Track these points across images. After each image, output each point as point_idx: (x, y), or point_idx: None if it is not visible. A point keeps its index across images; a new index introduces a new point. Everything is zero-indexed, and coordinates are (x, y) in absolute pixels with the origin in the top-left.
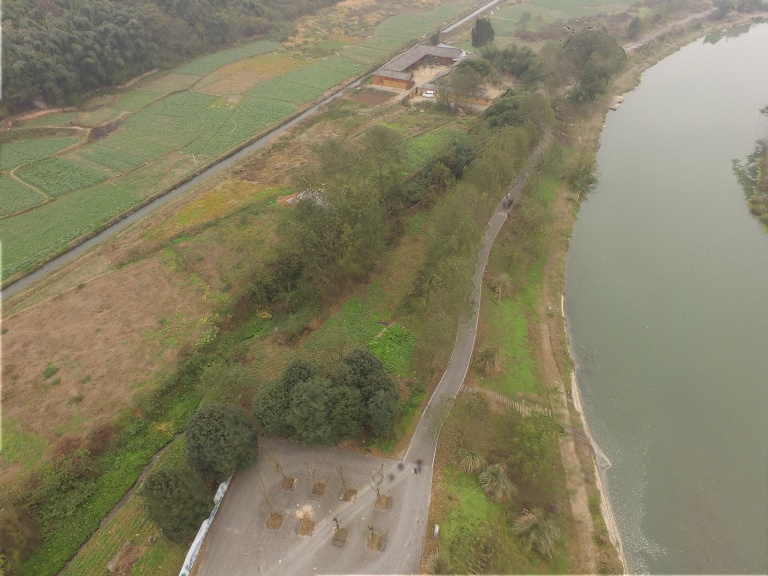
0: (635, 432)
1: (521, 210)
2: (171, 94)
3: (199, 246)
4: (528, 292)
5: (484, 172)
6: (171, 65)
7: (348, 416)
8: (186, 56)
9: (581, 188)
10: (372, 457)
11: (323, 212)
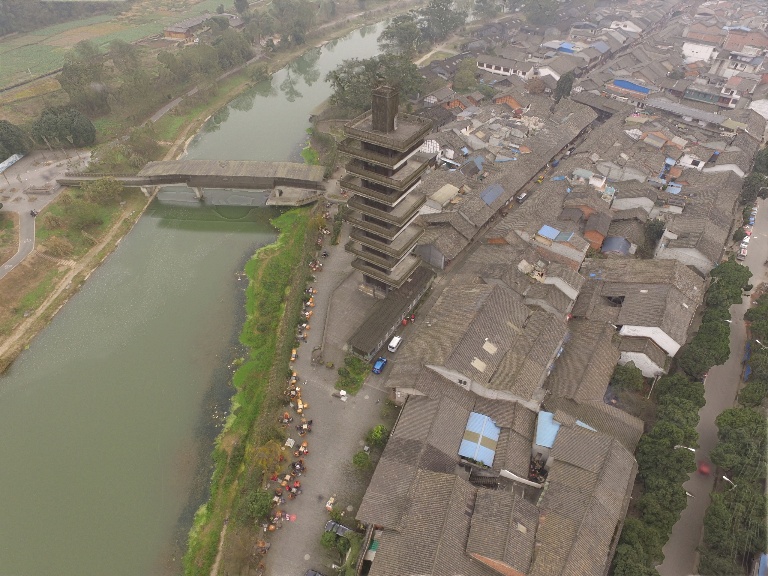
0: (205, 147)
1: (190, 77)
2: (25, 46)
3: (25, 104)
4: (193, 114)
5: (165, 57)
6: (28, 30)
7: (64, 126)
8: (40, 24)
9: (258, 80)
10: (83, 151)
11: (72, 69)
